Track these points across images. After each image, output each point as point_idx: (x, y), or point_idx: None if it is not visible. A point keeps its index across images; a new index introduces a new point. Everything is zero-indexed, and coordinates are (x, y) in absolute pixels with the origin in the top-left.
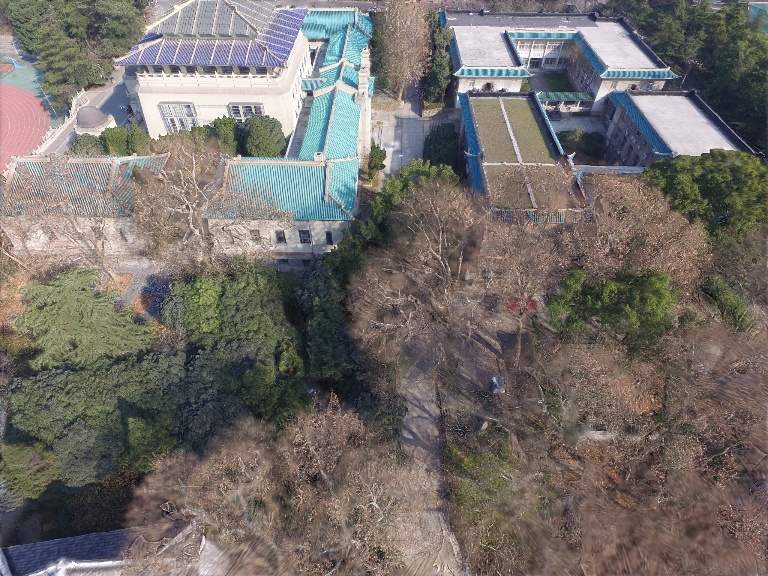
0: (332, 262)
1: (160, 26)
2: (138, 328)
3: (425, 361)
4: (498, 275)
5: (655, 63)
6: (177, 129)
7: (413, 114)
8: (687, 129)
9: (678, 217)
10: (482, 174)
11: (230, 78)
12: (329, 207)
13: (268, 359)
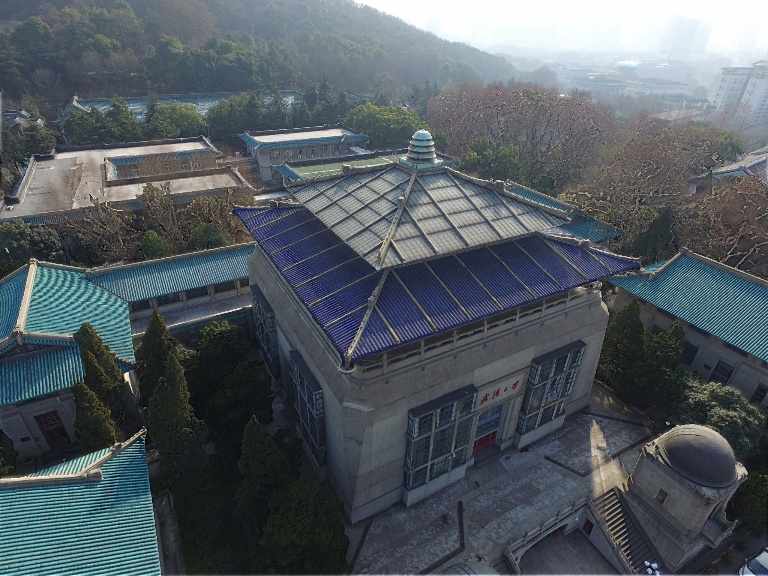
0: None
1: None
2: None
3: None
4: None
5: None
6: None
7: None
8: (302, 136)
9: (425, 125)
10: None
11: None
12: None
13: None
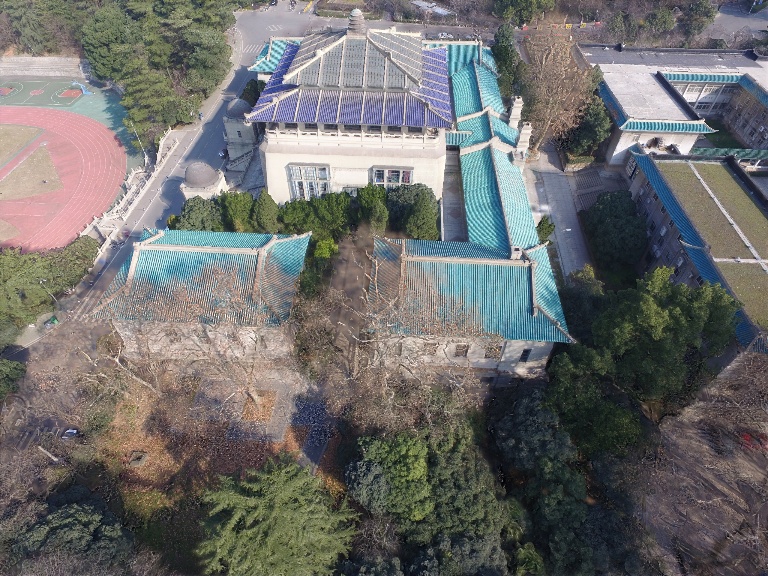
0: (557, 405)
1: (299, 75)
2: (334, 518)
3: (655, 526)
4: (733, 405)
5: None
6: (304, 193)
7: (553, 168)
8: None
9: None
10: (723, 278)
11: (378, 138)
12: (539, 323)
13: (504, 562)
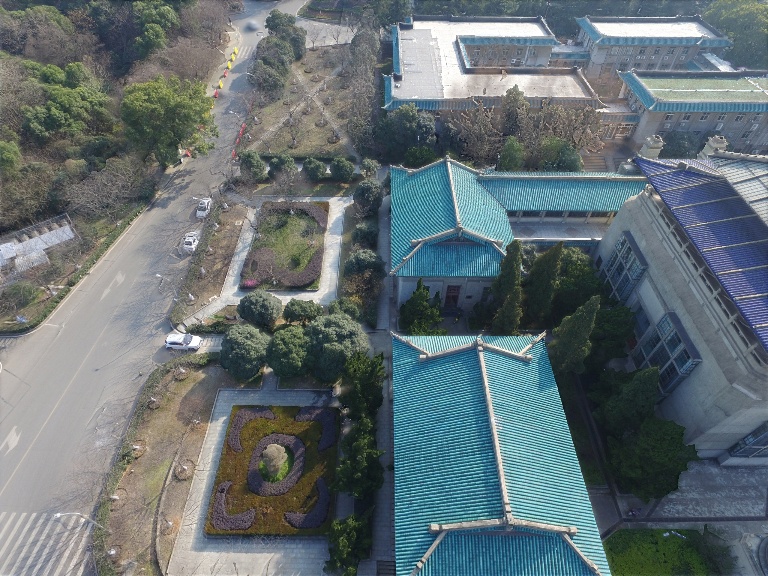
0: None
1: None
2: None
3: None
4: None
5: (520, 22)
6: None
7: None
8: (648, 30)
9: None
10: None
11: None
12: None
13: None
